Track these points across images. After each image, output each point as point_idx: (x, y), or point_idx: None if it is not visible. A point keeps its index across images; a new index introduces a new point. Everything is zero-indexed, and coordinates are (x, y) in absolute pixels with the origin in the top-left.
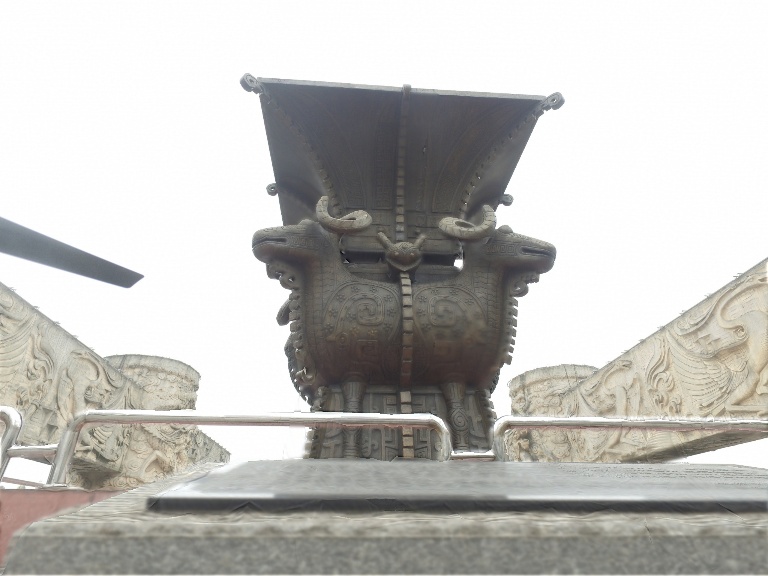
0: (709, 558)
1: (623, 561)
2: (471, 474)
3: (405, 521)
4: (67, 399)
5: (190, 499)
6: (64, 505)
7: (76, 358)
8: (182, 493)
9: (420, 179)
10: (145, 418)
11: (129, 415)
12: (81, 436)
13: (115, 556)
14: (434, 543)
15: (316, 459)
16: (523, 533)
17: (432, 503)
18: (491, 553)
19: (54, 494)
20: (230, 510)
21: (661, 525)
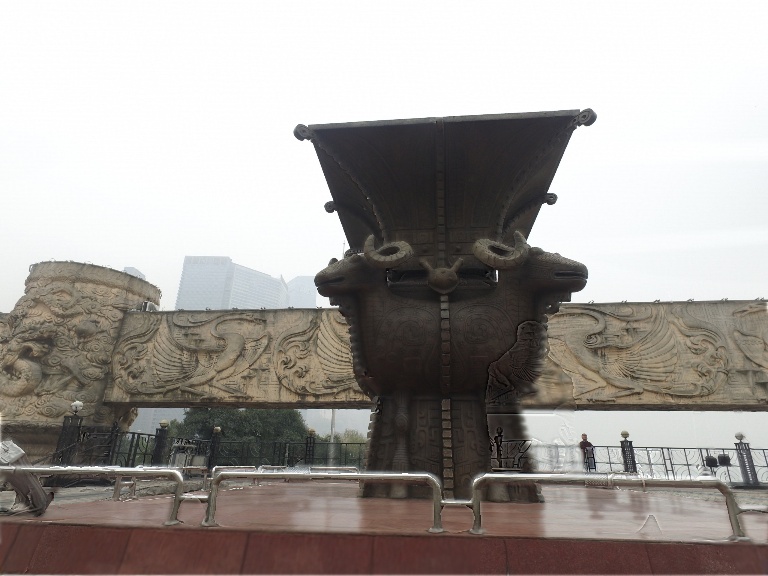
0: None
1: None
2: None
3: None
4: (766, 354)
5: None
6: None
7: (744, 316)
8: None
9: (378, 225)
10: None
11: None
12: None
13: None
14: None
15: None
16: None
17: None
18: None
19: None
20: None
21: None
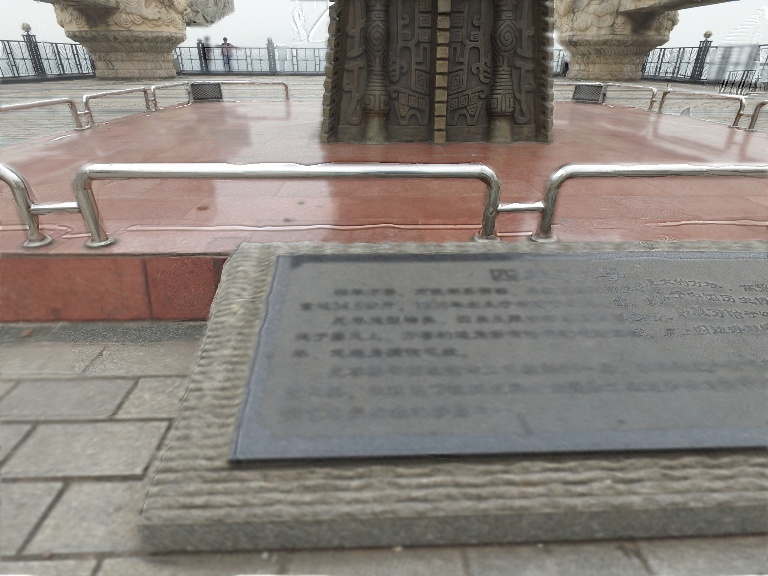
0: (712, 509)
1: (638, 513)
2: (521, 342)
3: (460, 492)
4: None
5: (264, 453)
6: (121, 268)
7: None
8: (256, 450)
9: None
10: (155, 175)
11: (136, 172)
12: (96, 193)
13: (224, 525)
14: (483, 510)
15: (361, 294)
16: (562, 502)
17: (484, 453)
18: (530, 512)
19: (105, 259)
20: (303, 462)
21: (687, 488)
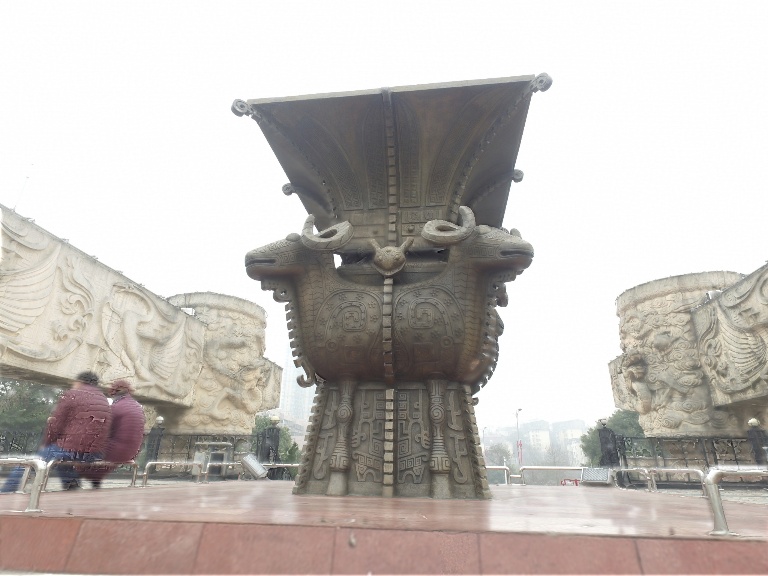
0: None
1: None
2: None
3: None
4: None
5: None
6: None
7: None
8: None
9: None
10: None
11: None
12: None
13: None
14: None
15: None
16: None
17: None
18: None
19: None
20: None
21: None
